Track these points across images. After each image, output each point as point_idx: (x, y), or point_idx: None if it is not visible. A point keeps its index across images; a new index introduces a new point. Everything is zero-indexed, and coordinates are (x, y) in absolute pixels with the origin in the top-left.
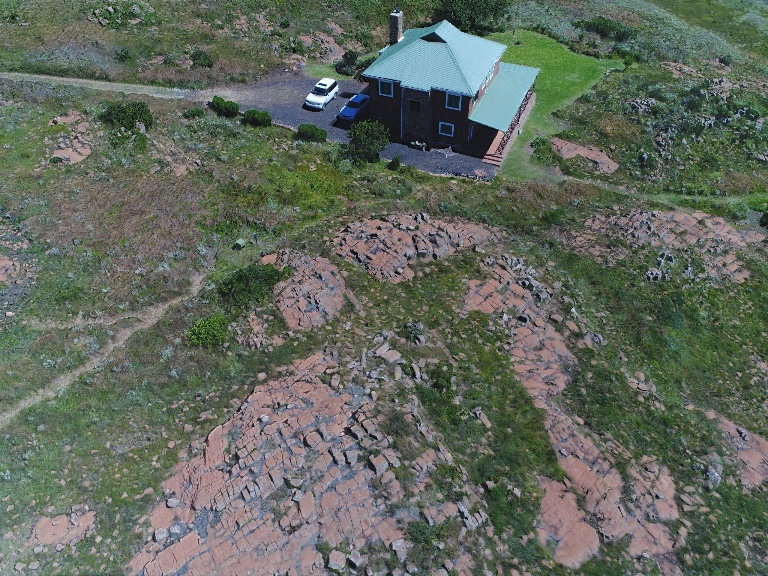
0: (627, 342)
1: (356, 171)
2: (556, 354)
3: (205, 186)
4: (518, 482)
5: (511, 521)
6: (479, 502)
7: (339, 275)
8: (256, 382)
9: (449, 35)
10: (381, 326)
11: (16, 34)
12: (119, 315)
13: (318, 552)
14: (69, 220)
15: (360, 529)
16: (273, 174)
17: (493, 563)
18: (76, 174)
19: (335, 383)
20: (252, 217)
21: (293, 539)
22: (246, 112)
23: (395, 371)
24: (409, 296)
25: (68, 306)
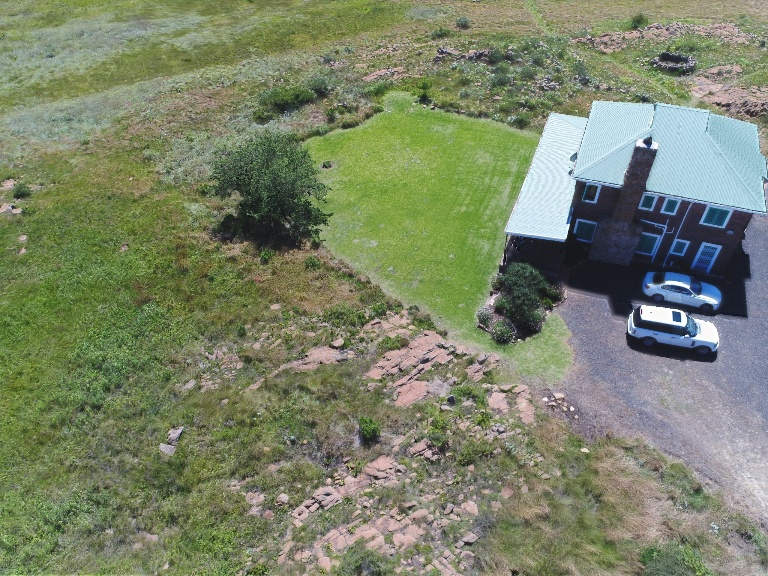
0: None
1: None
2: None
3: None
4: None
5: None
6: None
7: None
8: None
9: None
10: None
11: None
12: None
13: None
14: None
15: None
16: None
17: None
18: None
19: None
20: None
21: None
22: None
23: None
24: None
25: None
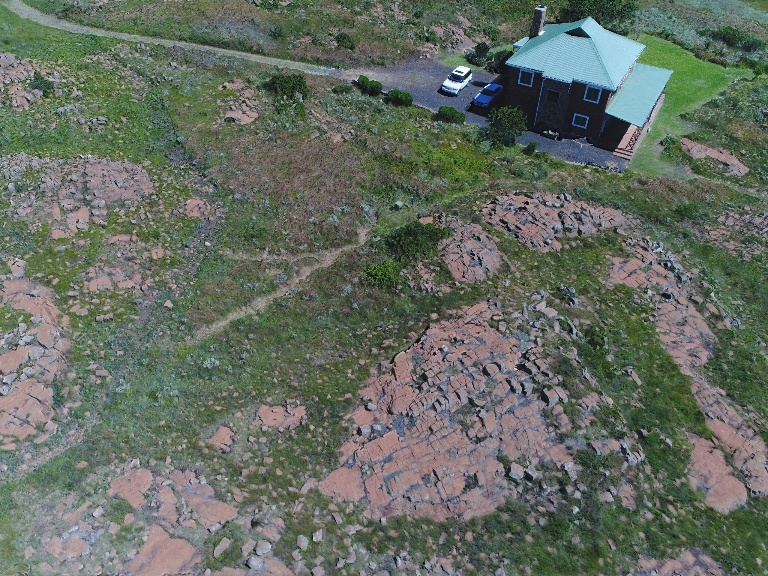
0: (764, 330)
1: (494, 153)
2: (698, 331)
3: (359, 153)
4: (669, 434)
5: (665, 465)
6: (635, 445)
7: (492, 240)
8: (430, 320)
9: (593, 31)
10: (536, 287)
11: (183, 8)
12: (299, 255)
13: (499, 462)
14: (247, 171)
15: (534, 449)
16: (420, 148)
17: (651, 496)
18: (247, 133)
19: (503, 328)
20: (406, 183)
21: (480, 448)
22: (390, 91)
23: (554, 325)
24: (558, 265)
25: (256, 242)
